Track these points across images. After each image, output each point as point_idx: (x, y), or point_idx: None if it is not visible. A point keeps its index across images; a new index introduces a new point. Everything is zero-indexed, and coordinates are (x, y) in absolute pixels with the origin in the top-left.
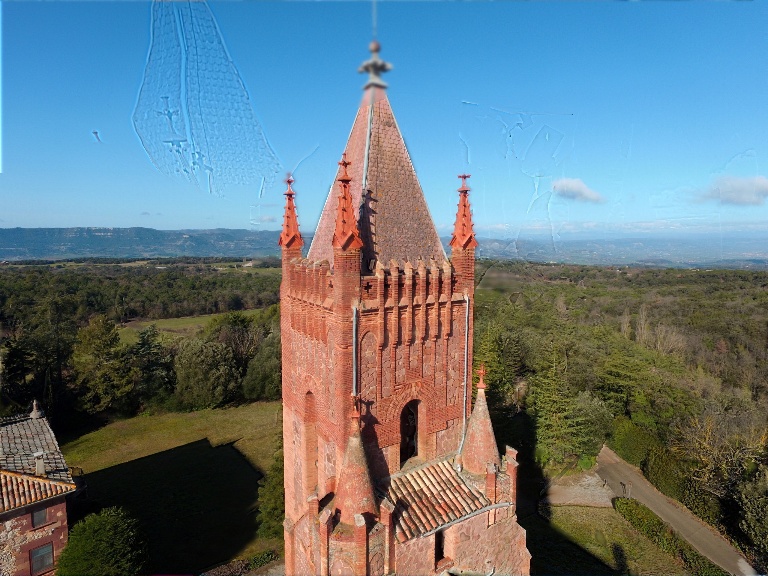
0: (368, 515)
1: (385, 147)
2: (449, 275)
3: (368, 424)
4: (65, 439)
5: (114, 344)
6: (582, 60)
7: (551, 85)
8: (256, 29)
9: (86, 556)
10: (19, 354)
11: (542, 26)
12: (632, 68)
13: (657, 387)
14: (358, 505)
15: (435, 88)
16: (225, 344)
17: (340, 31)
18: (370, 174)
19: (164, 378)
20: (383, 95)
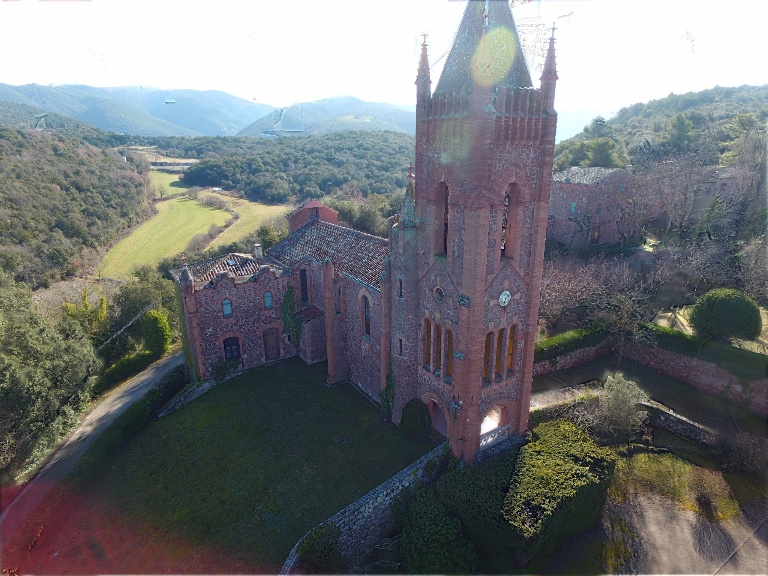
0: None
1: None
2: None
3: None
4: None
5: None
6: None
7: None
8: None
9: None
10: None
11: None
12: None
13: None
14: None
15: None
16: None
17: None
18: None
19: None
20: None
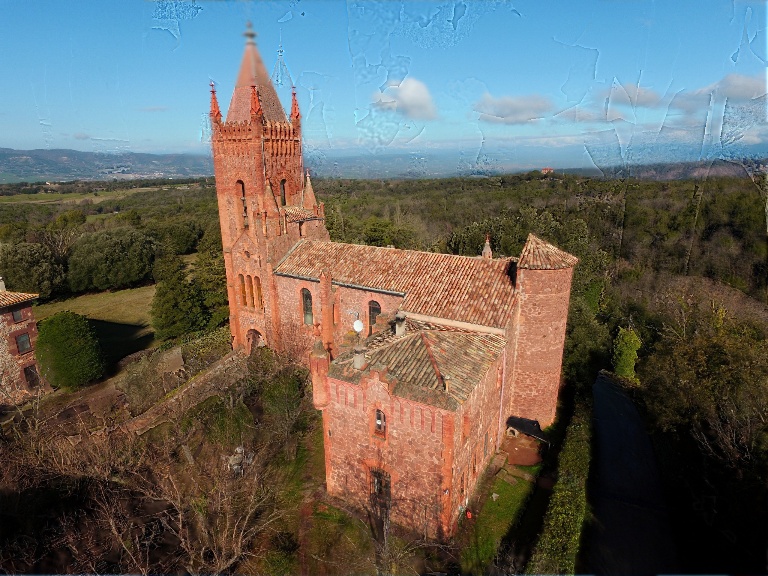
0: None
1: None
2: (292, 129)
3: None
4: None
5: None
6: (334, 70)
7: None
8: (290, 64)
9: (62, 333)
10: None
11: (328, 65)
12: (341, 72)
13: (396, 232)
14: (273, 209)
15: None
16: (39, 244)
17: (301, 65)
18: None
19: None
20: None
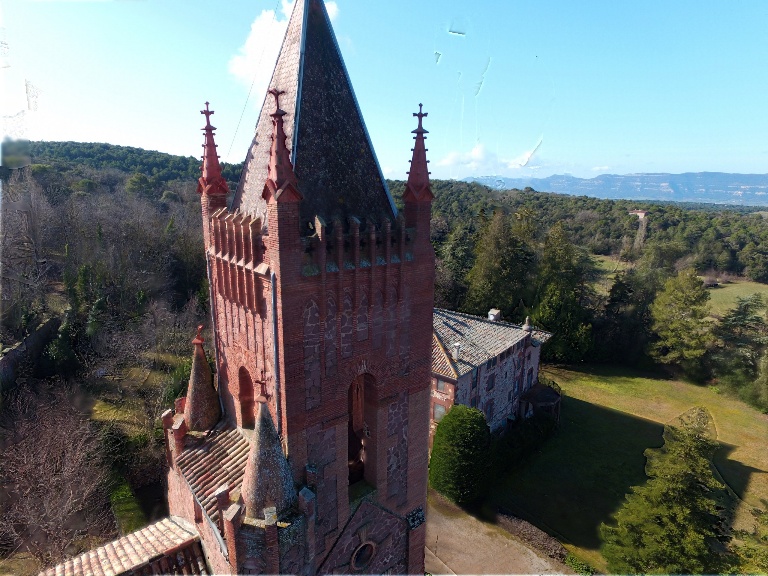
0: None
1: (283, 74)
2: (251, 236)
3: None
4: (626, 373)
5: (699, 302)
6: None
7: None
8: None
9: (442, 426)
10: (621, 287)
11: None
12: None
13: None
14: None
15: None
16: None
17: None
18: (263, 113)
19: (748, 360)
20: None
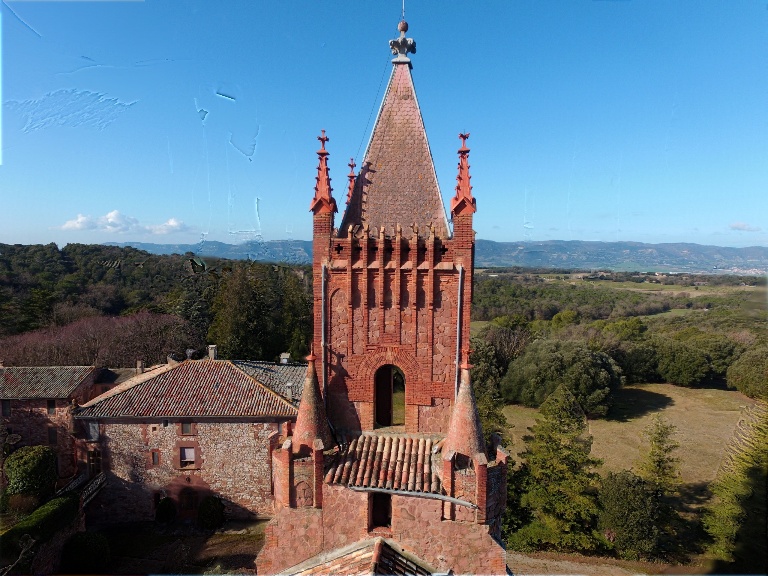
0: (306, 448)
1: (396, 120)
2: (431, 241)
3: (339, 375)
4: None
5: None
6: None
7: (31, 41)
8: None
9: None
10: None
11: None
12: (6, 14)
13: None
14: (300, 436)
15: (25, 64)
16: (489, 342)
17: None
18: (373, 147)
19: None
20: (12, 77)
